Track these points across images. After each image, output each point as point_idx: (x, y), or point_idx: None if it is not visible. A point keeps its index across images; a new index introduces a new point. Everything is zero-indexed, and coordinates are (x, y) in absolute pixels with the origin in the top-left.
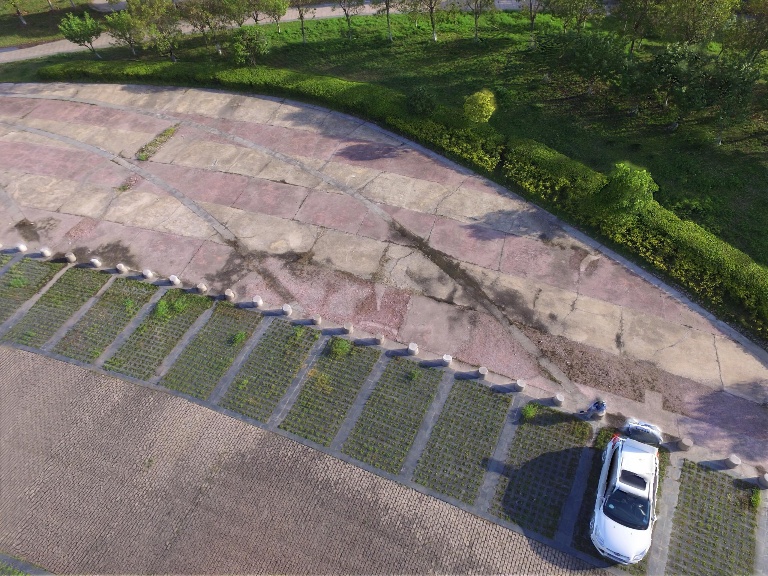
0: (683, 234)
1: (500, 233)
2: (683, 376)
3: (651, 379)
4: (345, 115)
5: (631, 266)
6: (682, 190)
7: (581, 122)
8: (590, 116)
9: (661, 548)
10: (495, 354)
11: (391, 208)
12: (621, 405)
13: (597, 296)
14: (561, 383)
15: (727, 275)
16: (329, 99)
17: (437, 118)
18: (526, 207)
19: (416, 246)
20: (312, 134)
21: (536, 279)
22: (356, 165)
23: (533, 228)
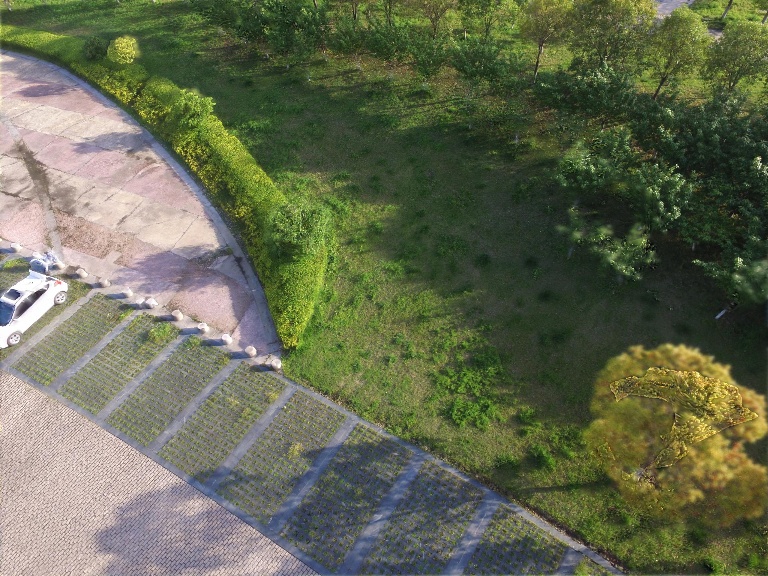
0: (219, 144)
1: (98, 148)
2: (148, 242)
3: (123, 244)
4: (48, 63)
5: (180, 171)
6: (255, 115)
7: (220, 65)
8: (232, 61)
9: (30, 344)
10: (20, 229)
11: (26, 131)
12: (84, 260)
13: (134, 191)
14: (53, 247)
15: (228, 172)
16: (36, 49)
17: (105, 62)
18: (136, 130)
19: (23, 158)
20: (8, 77)
21: (97, 180)
22: (25, 100)
23: (128, 145)
